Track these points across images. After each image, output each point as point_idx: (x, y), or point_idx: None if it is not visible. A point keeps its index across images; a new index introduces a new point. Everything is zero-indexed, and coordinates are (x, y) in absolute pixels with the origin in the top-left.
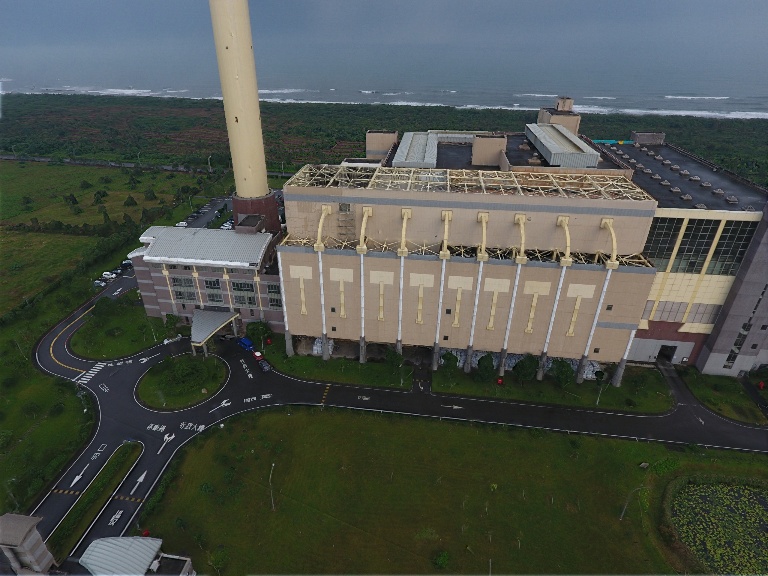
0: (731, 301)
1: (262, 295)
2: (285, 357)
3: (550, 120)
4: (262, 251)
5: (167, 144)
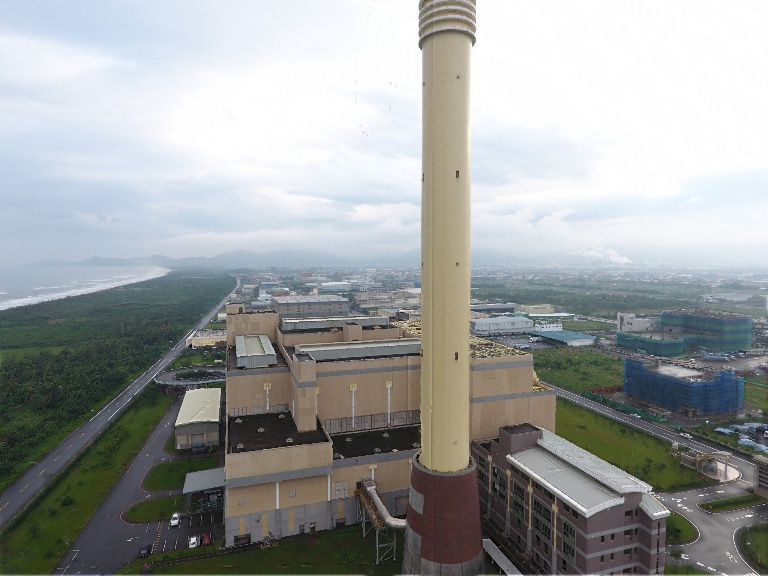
0: None
1: None
2: None
3: None
4: None
5: None
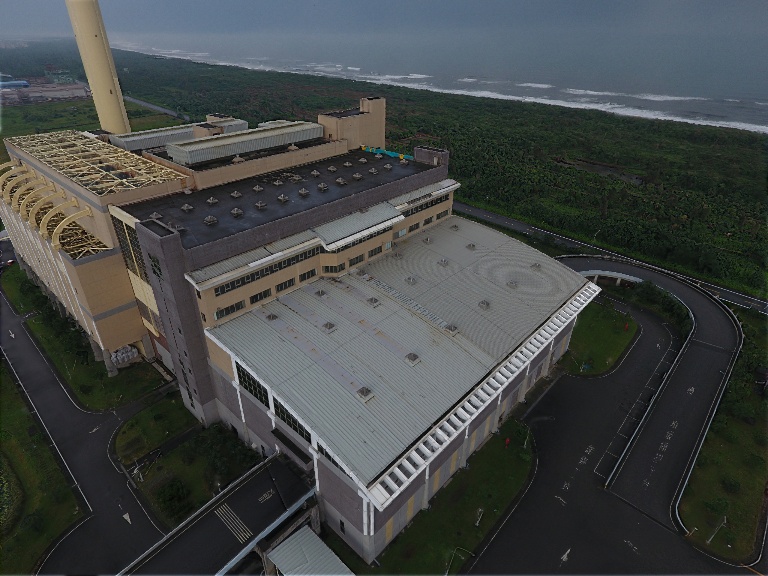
0: None
1: None
2: (3, 266)
3: None
4: None
5: (289, 119)
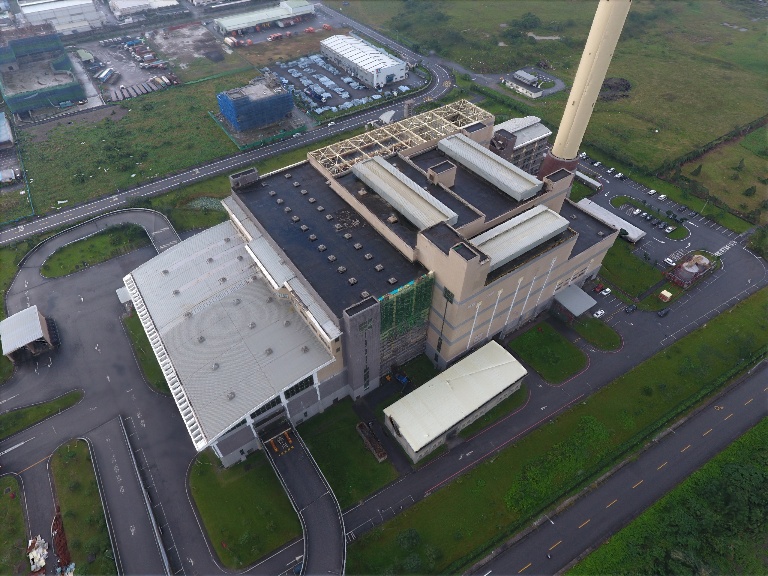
0: None
1: None
2: None
3: None
4: None
5: None
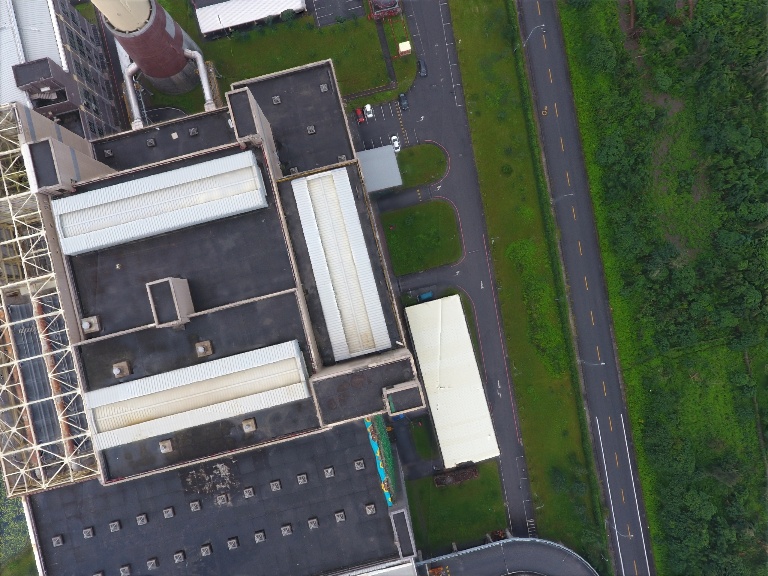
0: None
1: None
2: None
3: (310, 378)
4: None
5: None
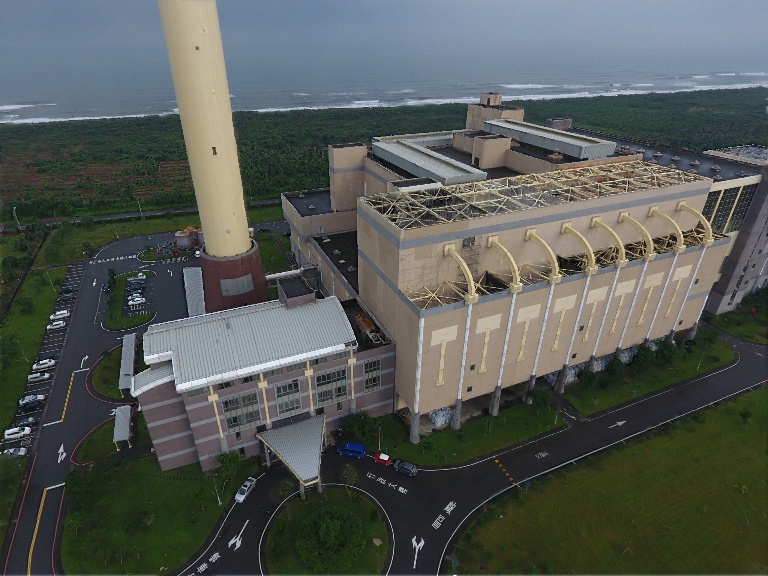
0: (740, 251)
1: (356, 379)
2: (430, 447)
3: (501, 115)
4: (348, 323)
5: None
